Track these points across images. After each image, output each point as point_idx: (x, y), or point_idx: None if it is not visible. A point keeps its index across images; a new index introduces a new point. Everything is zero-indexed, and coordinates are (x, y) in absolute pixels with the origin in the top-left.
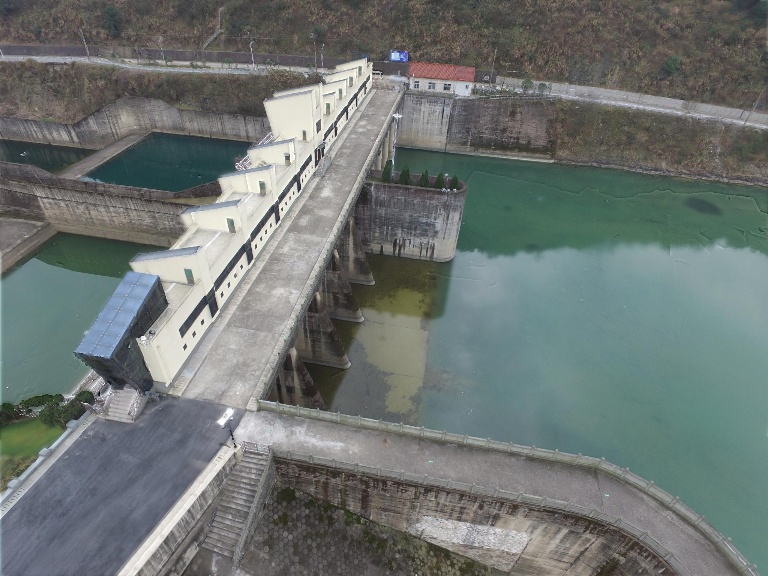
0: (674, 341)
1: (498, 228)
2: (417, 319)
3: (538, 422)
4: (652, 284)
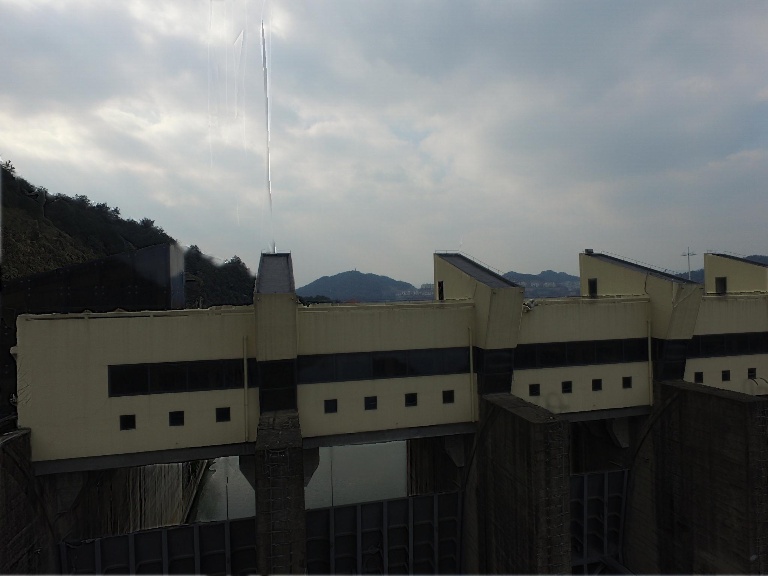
0: None
1: None
2: None
3: None
4: None
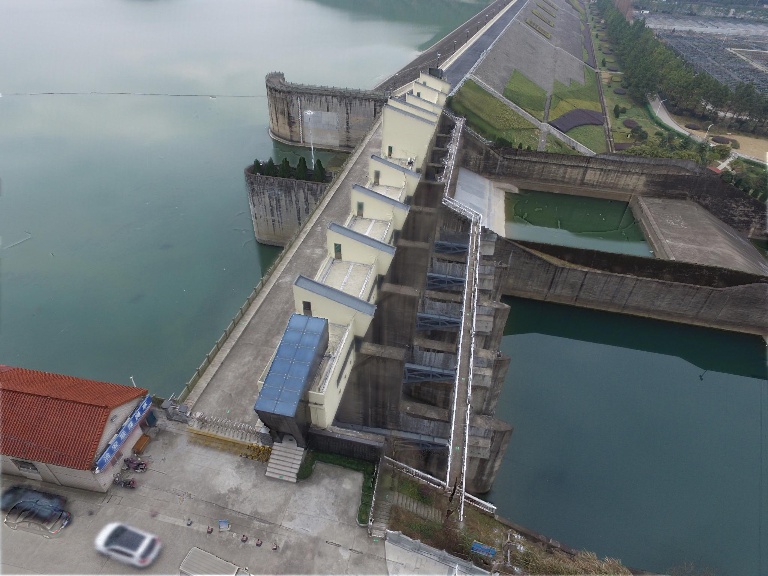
0: None
1: (180, 270)
2: None
3: None
4: (99, 214)
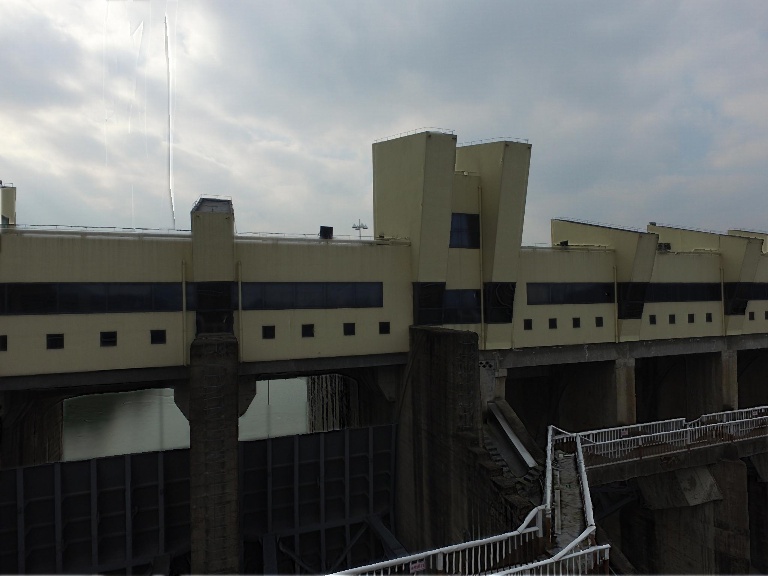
0: None
1: None
2: None
3: None
4: None
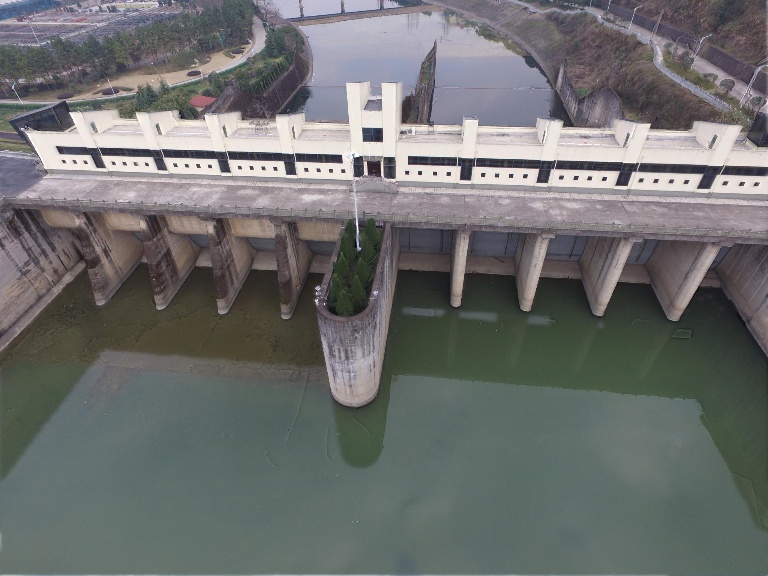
0: None
1: (472, 501)
2: (213, 361)
3: (6, 480)
4: None
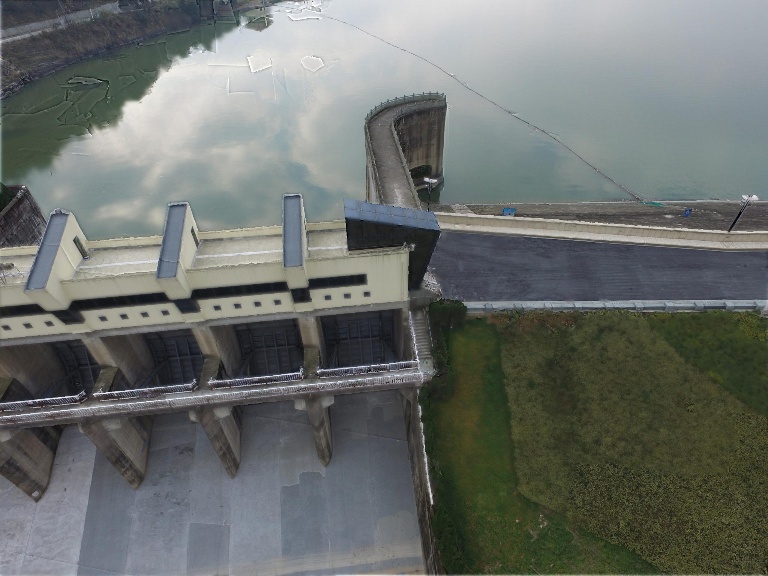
0: (202, 161)
1: None
2: None
3: None
4: (133, 164)
